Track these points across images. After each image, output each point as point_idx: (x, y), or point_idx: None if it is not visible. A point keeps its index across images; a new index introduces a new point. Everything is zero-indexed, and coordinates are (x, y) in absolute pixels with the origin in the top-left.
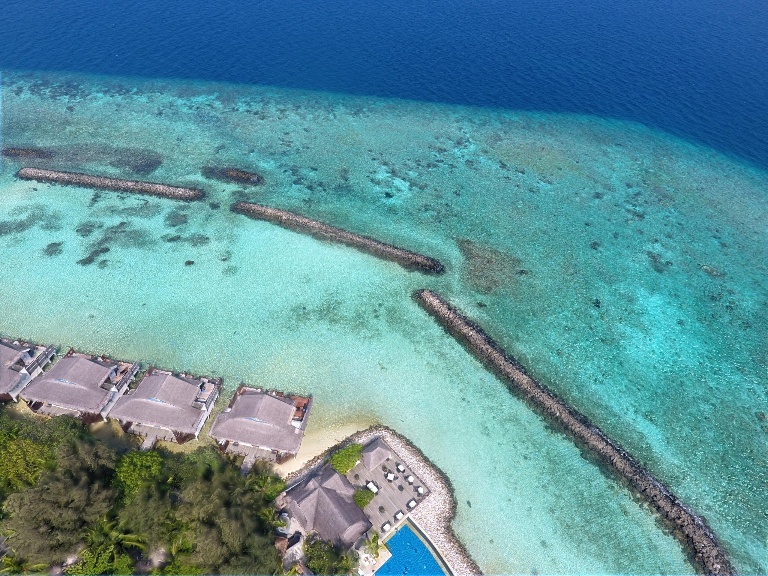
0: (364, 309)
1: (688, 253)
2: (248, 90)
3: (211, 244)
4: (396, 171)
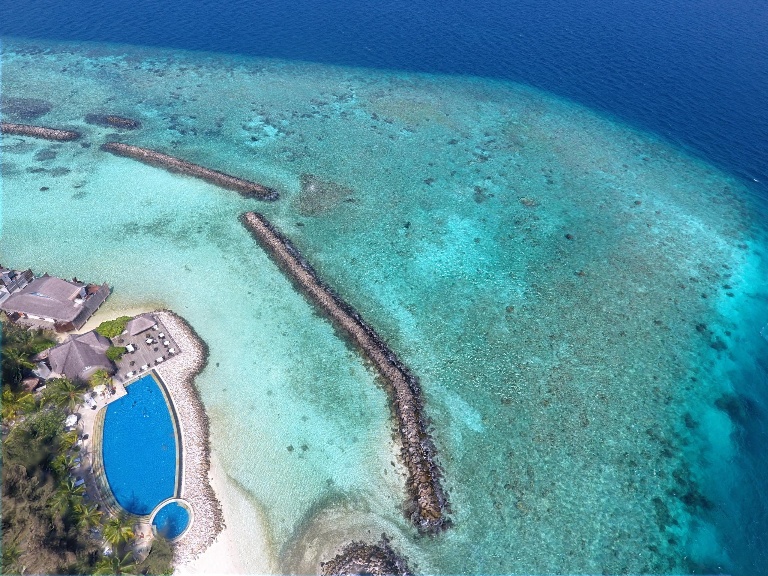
0: (190, 226)
1: (513, 188)
2: (157, 52)
3: (70, 175)
4: (270, 120)
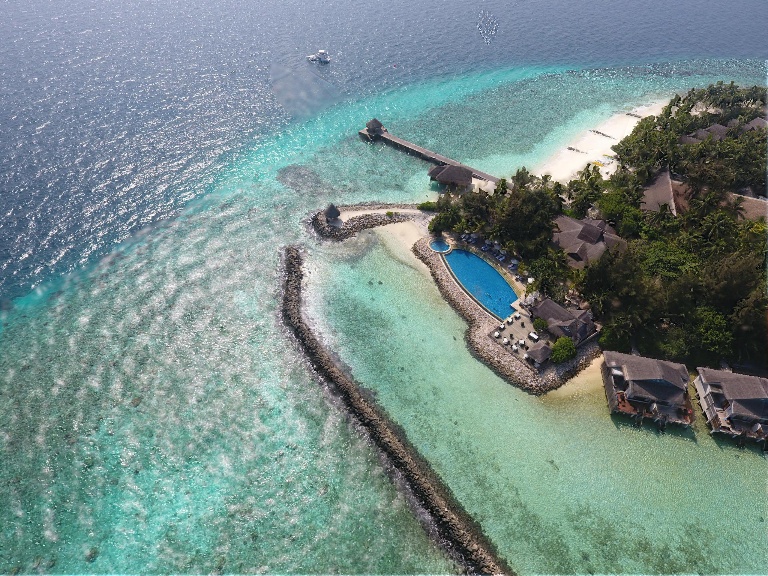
0: (610, 574)
1: None
2: None
3: None
4: None
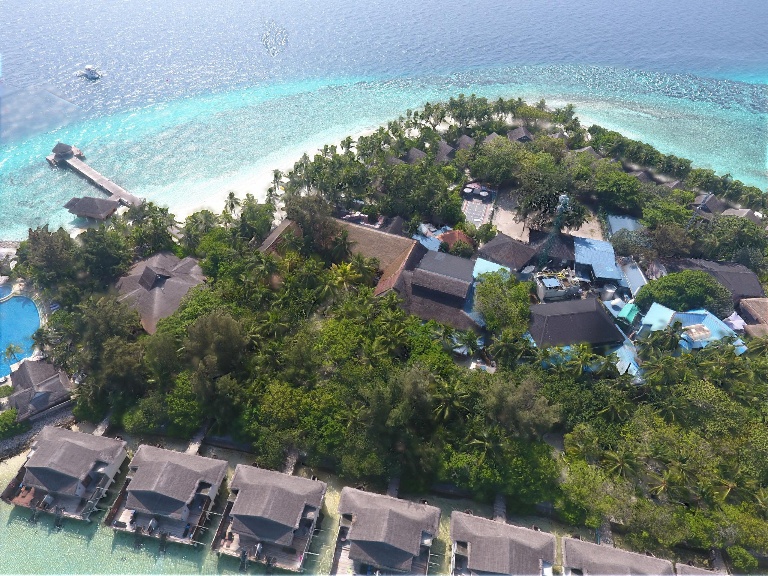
0: None
1: None
2: None
3: None
4: None
